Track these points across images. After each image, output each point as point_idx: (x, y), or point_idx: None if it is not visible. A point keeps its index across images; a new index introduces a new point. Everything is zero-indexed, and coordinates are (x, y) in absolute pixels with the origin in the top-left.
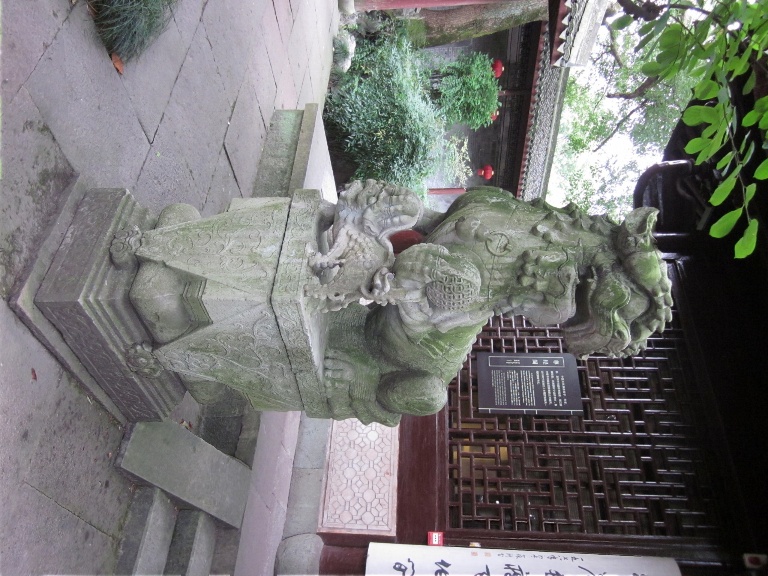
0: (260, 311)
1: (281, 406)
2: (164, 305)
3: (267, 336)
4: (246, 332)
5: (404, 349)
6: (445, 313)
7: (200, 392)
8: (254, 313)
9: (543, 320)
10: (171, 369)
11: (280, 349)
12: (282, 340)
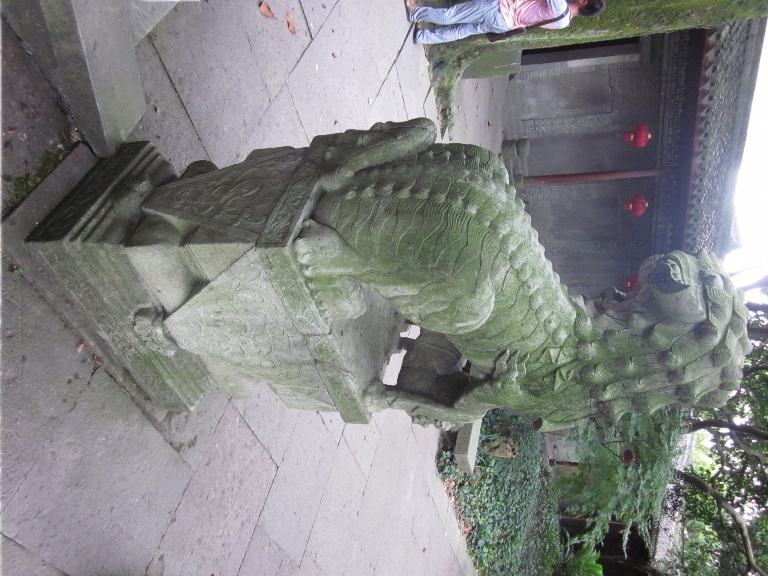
0: None
1: None
2: None
3: None
4: None
5: None
6: None
7: None
8: None
9: None
10: None
11: None
12: None
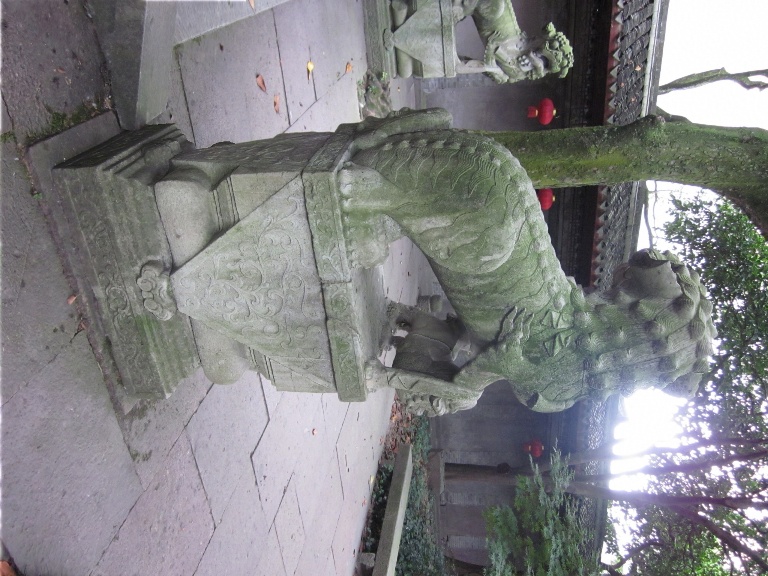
0: None
1: None
2: None
3: None
4: None
5: None
6: None
7: None
8: None
9: None
10: None
11: None
12: None
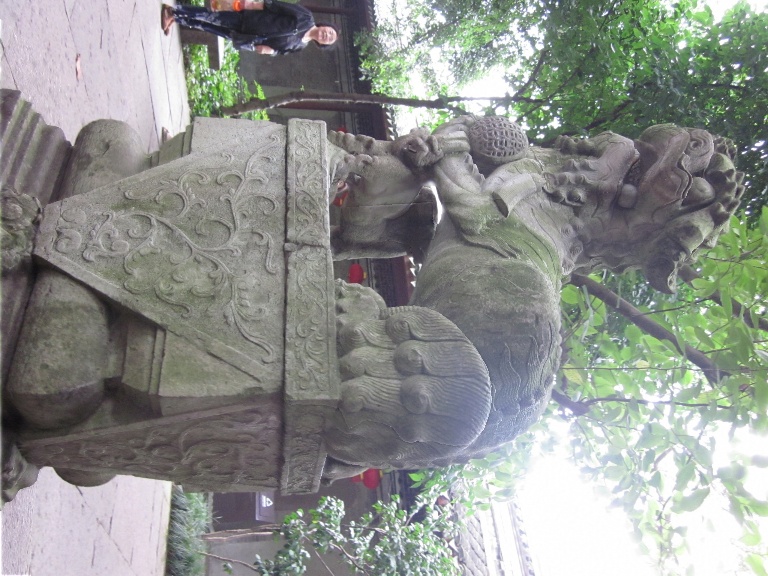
0: (268, 136)
1: (230, 371)
2: (128, 136)
3: (264, 176)
4: (234, 169)
5: (460, 258)
6: (500, 173)
7: (53, 340)
8: (258, 139)
9: (612, 162)
10: (45, 255)
11: (276, 201)
12: (284, 185)
